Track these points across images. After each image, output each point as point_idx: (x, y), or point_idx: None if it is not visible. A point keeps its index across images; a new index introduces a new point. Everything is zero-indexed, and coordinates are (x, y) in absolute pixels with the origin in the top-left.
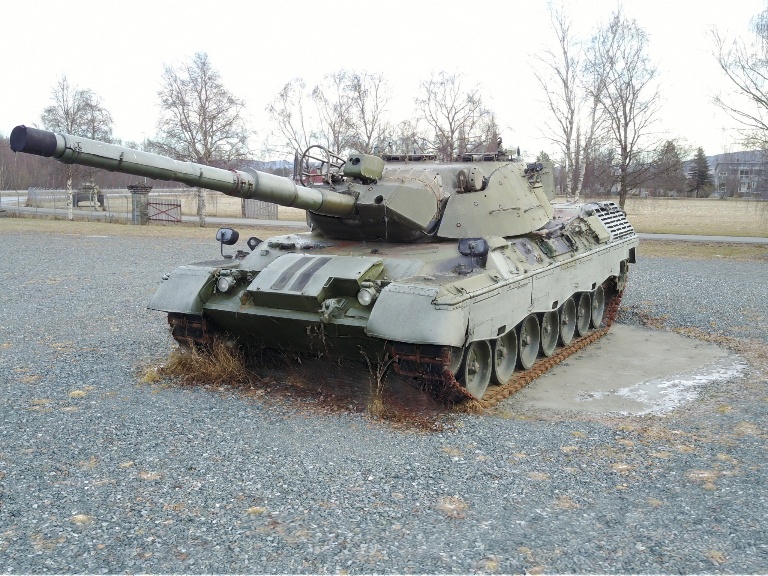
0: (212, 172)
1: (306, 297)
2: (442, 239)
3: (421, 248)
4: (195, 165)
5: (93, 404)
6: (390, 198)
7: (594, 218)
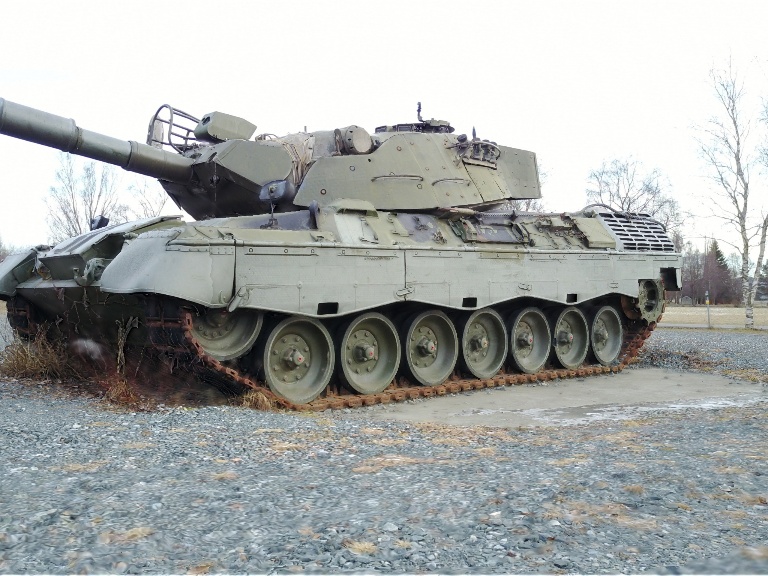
0: None
1: (73, 257)
2: (301, 209)
3: None
4: None
5: None
6: (222, 153)
7: (593, 220)
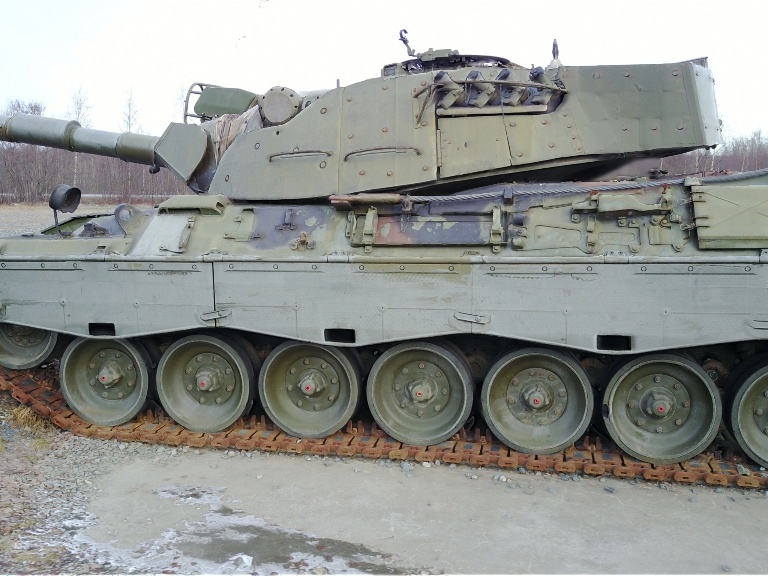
0: None
1: None
2: None
3: None
4: None
5: None
6: (160, 140)
7: None
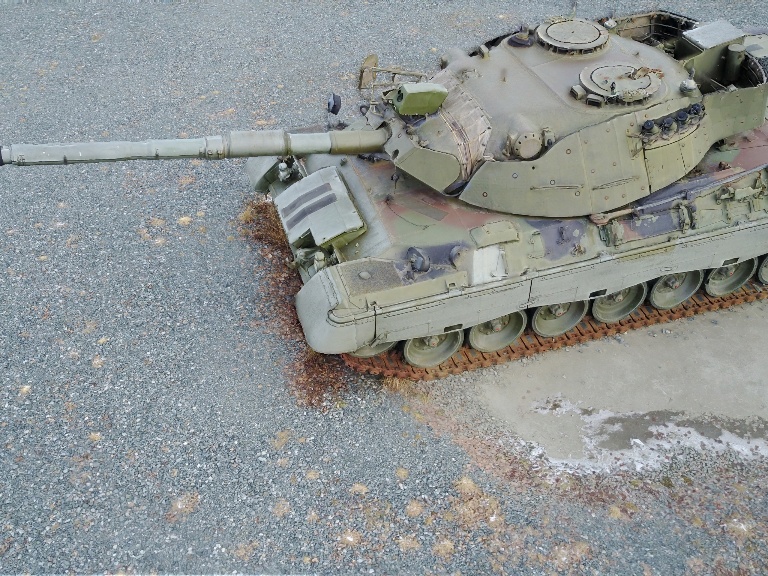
0: (171, 150)
1: None
2: None
3: (432, 210)
4: (153, 146)
5: (179, 240)
6: (402, 158)
7: None
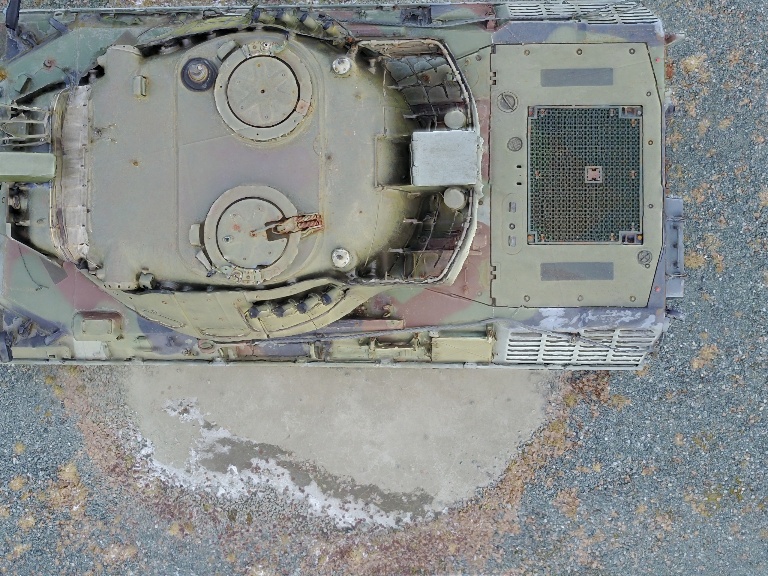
0: None
1: None
2: None
3: None
4: None
5: None
6: None
7: (479, 341)
